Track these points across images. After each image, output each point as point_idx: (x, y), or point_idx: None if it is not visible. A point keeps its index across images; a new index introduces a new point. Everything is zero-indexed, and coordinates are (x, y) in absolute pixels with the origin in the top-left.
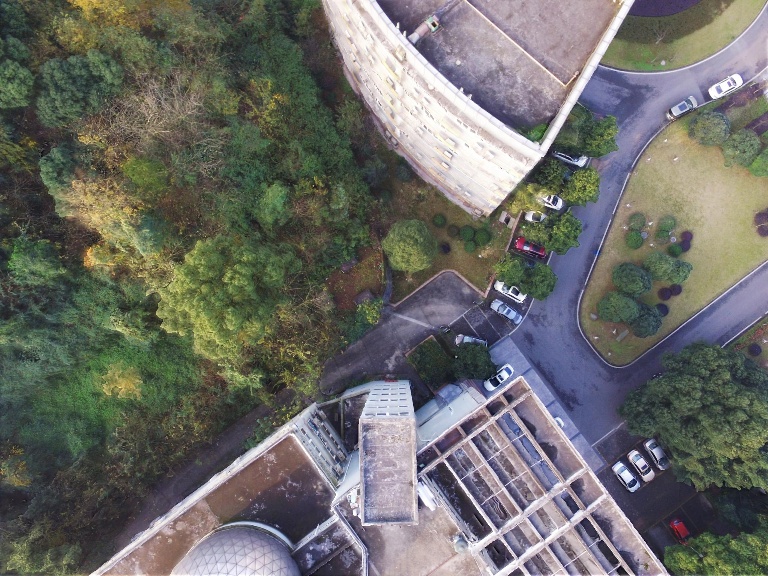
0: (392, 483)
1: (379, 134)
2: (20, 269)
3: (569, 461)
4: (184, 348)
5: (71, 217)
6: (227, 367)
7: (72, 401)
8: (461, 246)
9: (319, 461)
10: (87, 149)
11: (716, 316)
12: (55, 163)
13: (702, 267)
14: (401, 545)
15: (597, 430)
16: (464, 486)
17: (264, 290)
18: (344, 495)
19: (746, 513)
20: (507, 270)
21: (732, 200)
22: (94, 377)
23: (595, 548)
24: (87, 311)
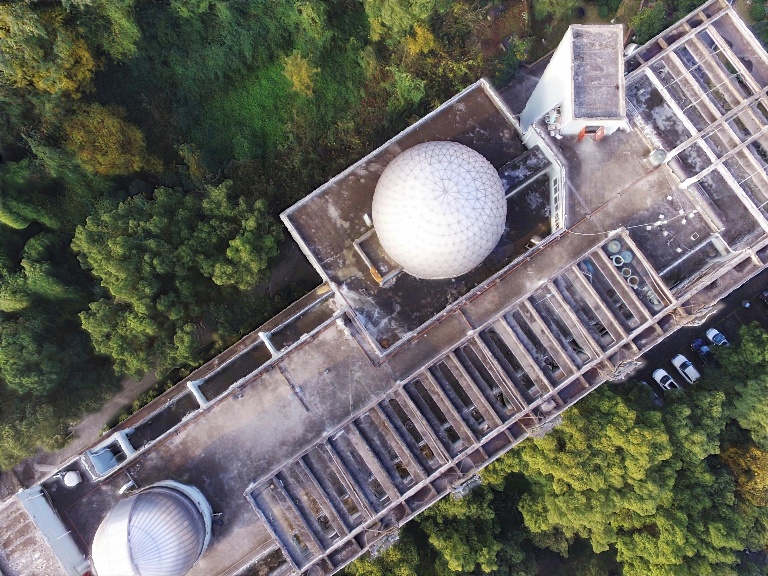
0: (599, 86)
1: None
2: None
3: (764, 74)
4: (346, 66)
5: None
6: (394, 70)
7: (238, 110)
8: (594, 11)
9: None
10: None
11: None
12: None
13: None
14: (596, 164)
15: None
16: (666, 91)
17: None
18: (543, 115)
19: None
20: (647, 16)
21: None
22: (262, 86)
23: None
24: (270, 3)
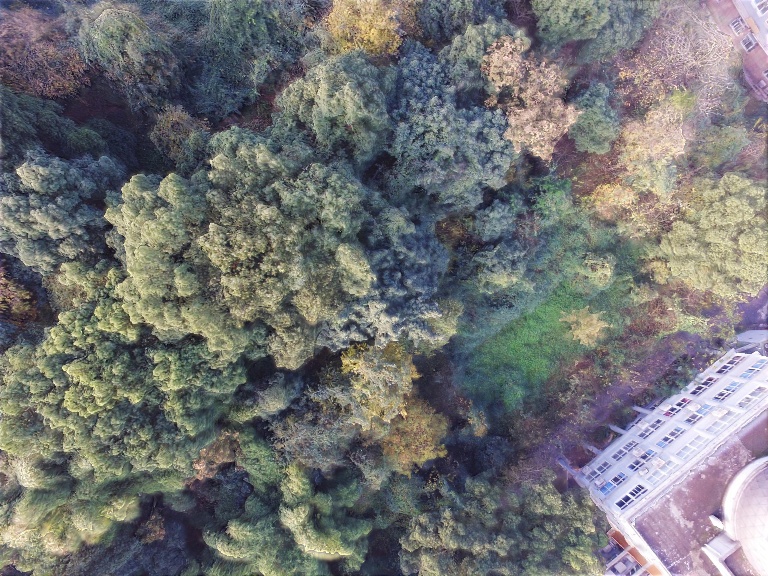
0: None
1: (747, 85)
2: (548, 208)
3: None
4: (612, 296)
5: (596, 155)
6: (678, 311)
7: (506, 352)
8: None
9: None
10: (619, 85)
11: None
12: (602, 98)
13: None
14: None
15: None
16: None
17: None
18: None
19: None
20: None
21: None
22: (530, 327)
23: None
24: (555, 257)
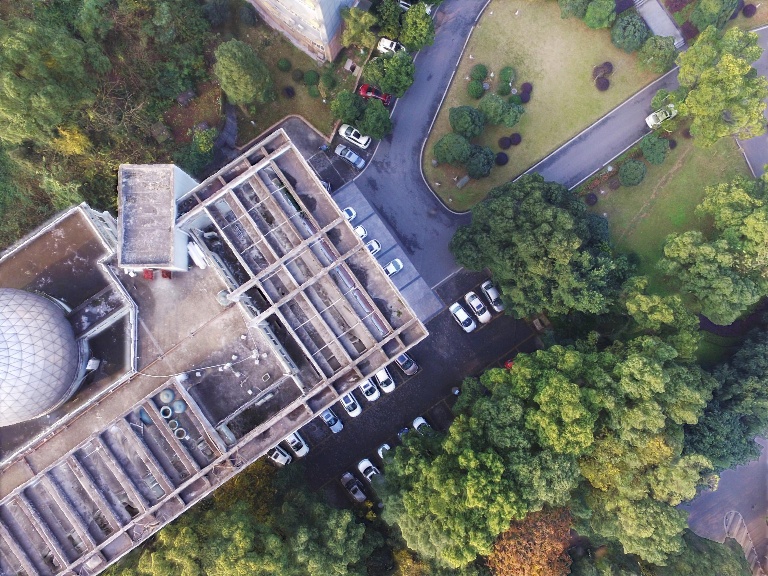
0: (151, 229)
1: None
2: None
3: (327, 212)
4: (10, 165)
5: None
6: (44, 175)
7: None
8: (306, 91)
9: (107, 237)
10: None
11: (555, 167)
12: None
13: (542, 119)
14: (171, 303)
15: (437, 273)
16: (223, 233)
17: (64, 78)
18: (115, 252)
19: (567, 341)
20: (340, 103)
21: (571, 54)
22: None
23: (350, 296)
24: None
